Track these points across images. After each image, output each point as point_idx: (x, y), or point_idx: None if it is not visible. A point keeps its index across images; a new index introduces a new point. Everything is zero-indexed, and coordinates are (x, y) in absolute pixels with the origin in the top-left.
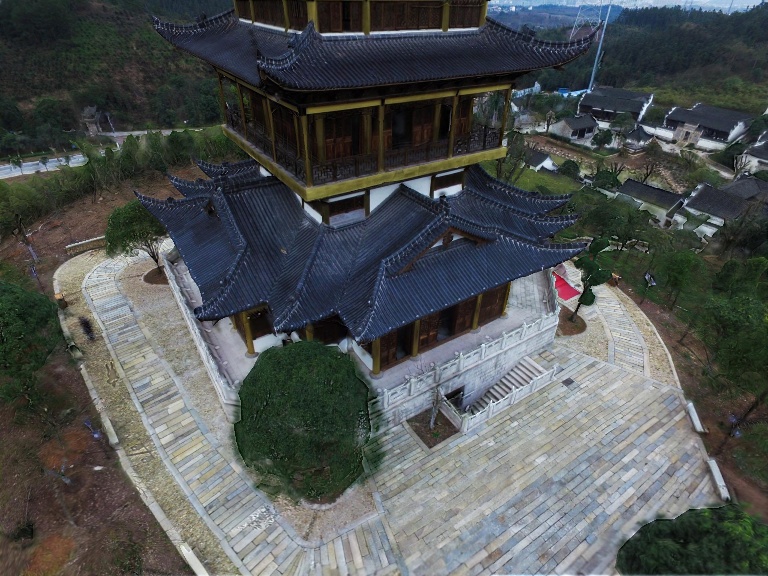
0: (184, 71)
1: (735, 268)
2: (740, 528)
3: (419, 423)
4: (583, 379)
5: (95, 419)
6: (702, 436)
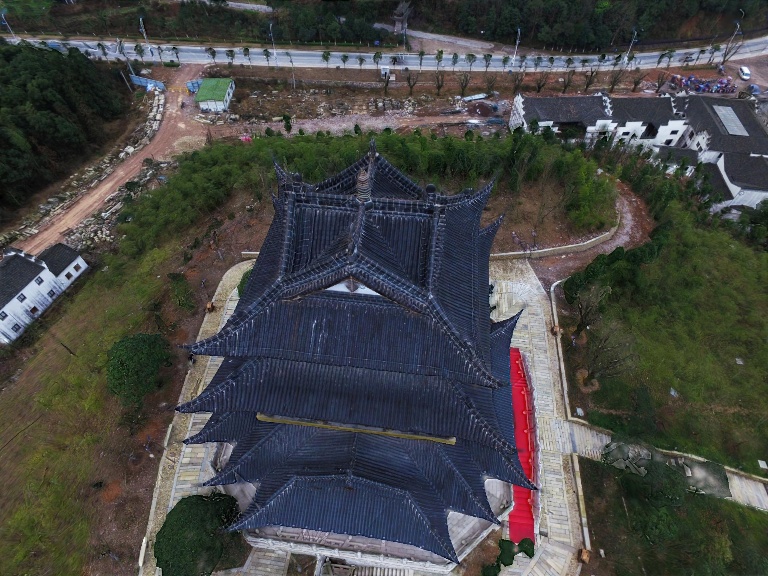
0: None
1: None
2: None
3: (296, 561)
4: None
5: (170, 419)
6: None
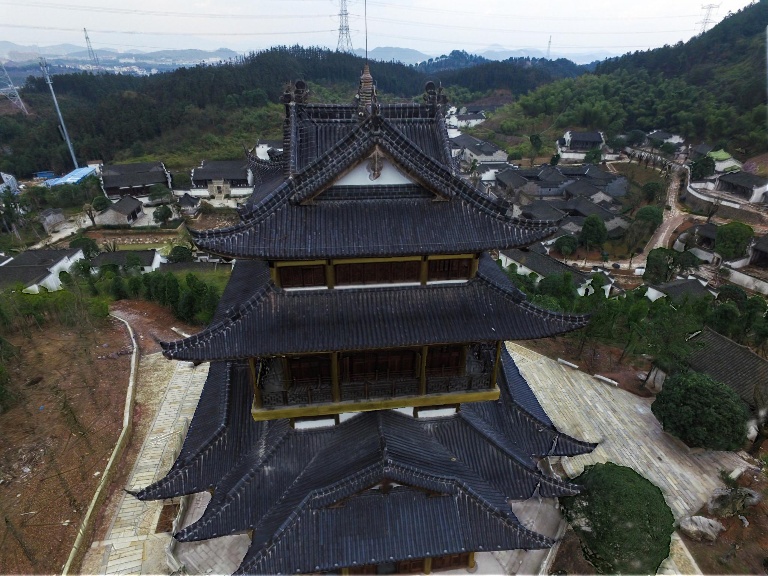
0: None
1: None
2: (690, 382)
3: None
4: None
5: None
6: (578, 369)
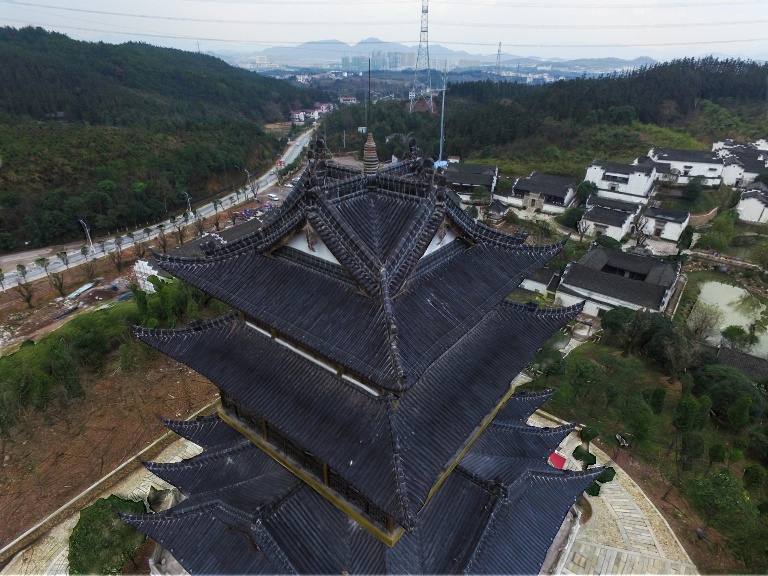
0: (15, 183)
1: (663, 395)
2: None
3: None
4: None
5: None
6: None
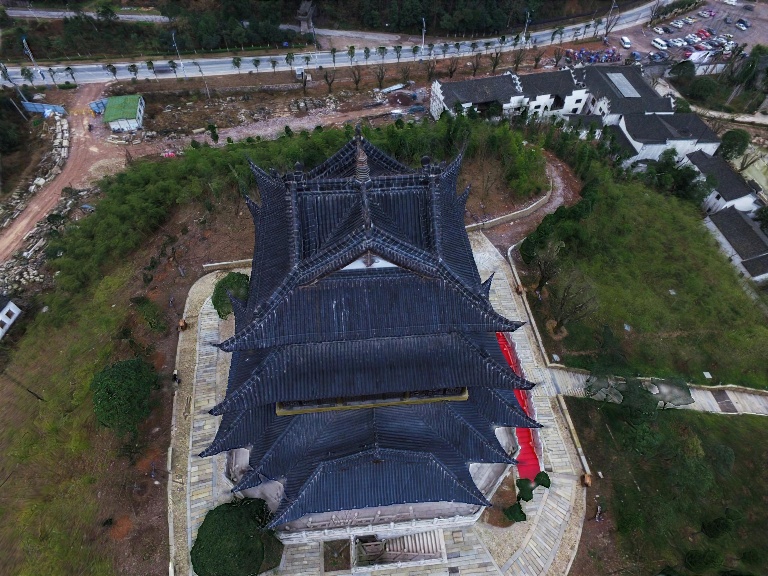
0: None
1: (726, 529)
2: None
3: (330, 548)
4: (467, 574)
5: (167, 443)
6: None
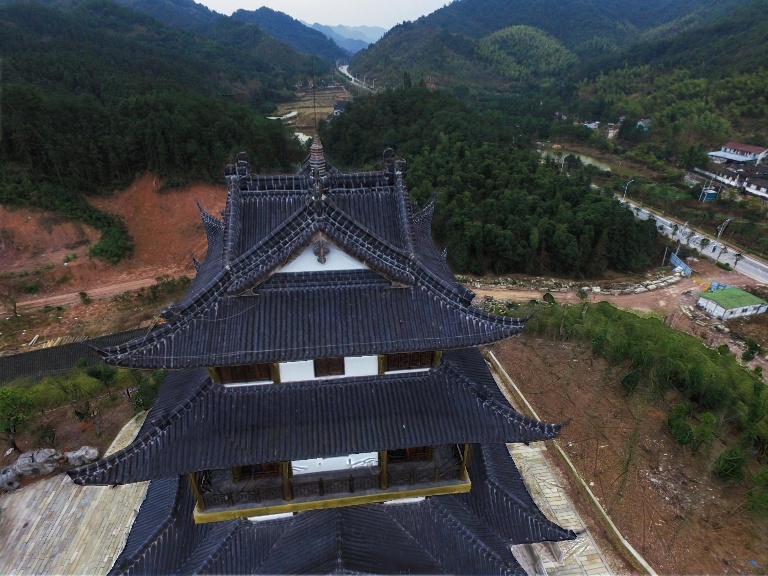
0: None
1: None
2: None
3: None
4: None
5: None
6: None
